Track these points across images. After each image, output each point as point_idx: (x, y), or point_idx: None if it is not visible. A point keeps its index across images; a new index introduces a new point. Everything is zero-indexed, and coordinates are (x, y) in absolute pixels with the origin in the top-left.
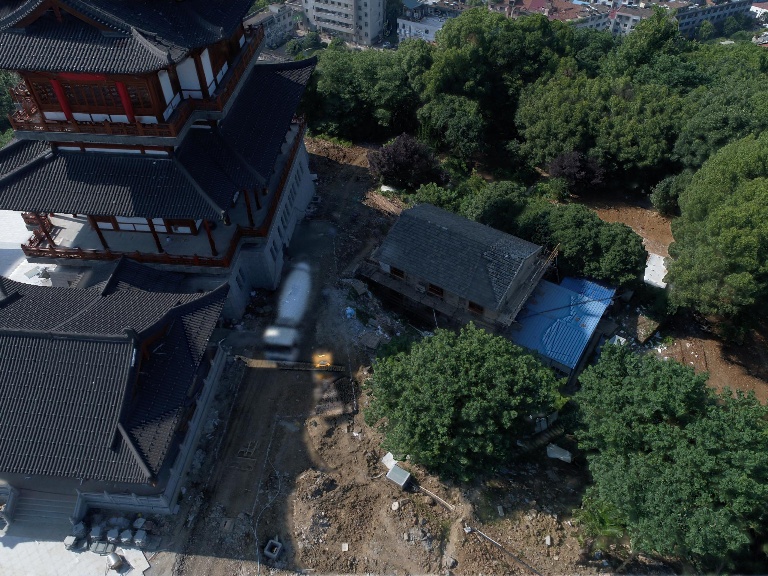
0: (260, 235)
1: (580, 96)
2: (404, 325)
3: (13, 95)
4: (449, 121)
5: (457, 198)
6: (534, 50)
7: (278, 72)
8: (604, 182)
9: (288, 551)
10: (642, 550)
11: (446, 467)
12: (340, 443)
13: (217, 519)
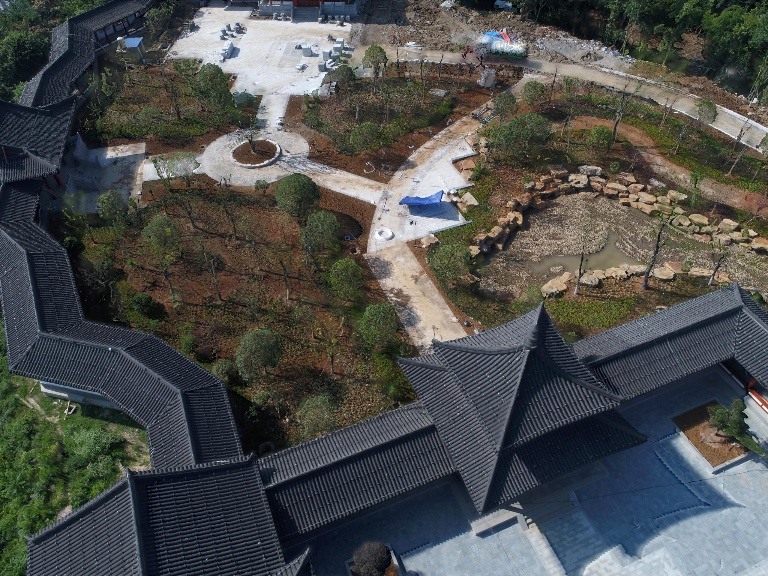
0: None
1: None
2: None
3: None
4: None
5: None
6: None
7: None
8: None
9: None
10: (543, 5)
11: (468, 2)
12: (422, 2)
13: (375, 18)
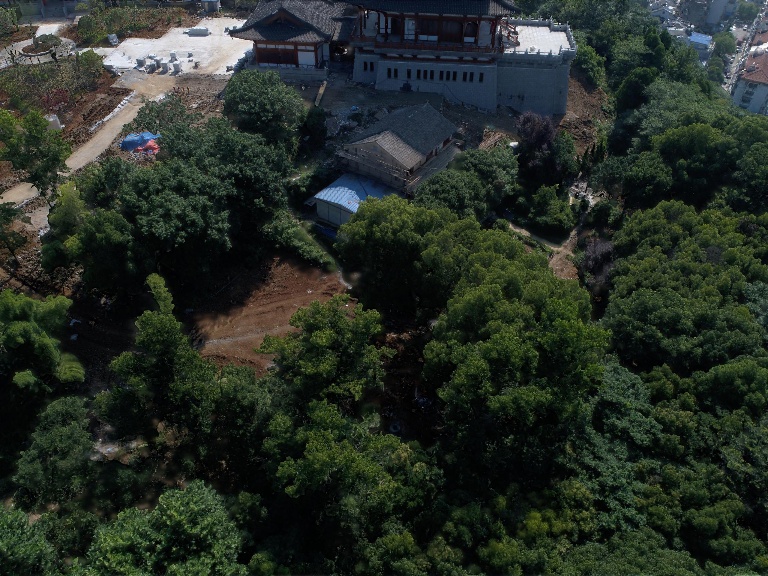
0: None
1: None
2: None
3: None
4: None
5: (531, 191)
6: (757, 181)
7: (492, 1)
8: (598, 292)
9: None
10: None
11: None
12: None
13: None
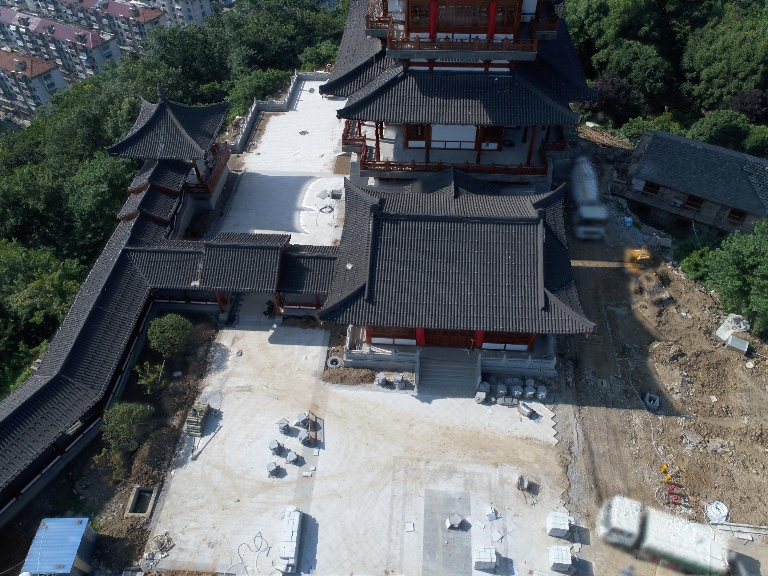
0: (560, 149)
1: (753, 38)
2: (668, 234)
3: (367, 21)
4: (635, 63)
5: None
6: None
7: None
8: None
9: (663, 403)
10: None
11: None
12: (672, 321)
13: (593, 380)
